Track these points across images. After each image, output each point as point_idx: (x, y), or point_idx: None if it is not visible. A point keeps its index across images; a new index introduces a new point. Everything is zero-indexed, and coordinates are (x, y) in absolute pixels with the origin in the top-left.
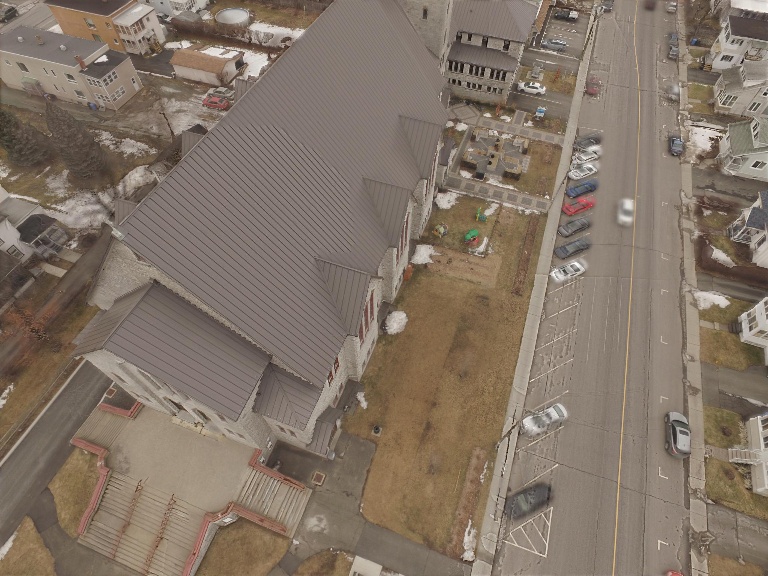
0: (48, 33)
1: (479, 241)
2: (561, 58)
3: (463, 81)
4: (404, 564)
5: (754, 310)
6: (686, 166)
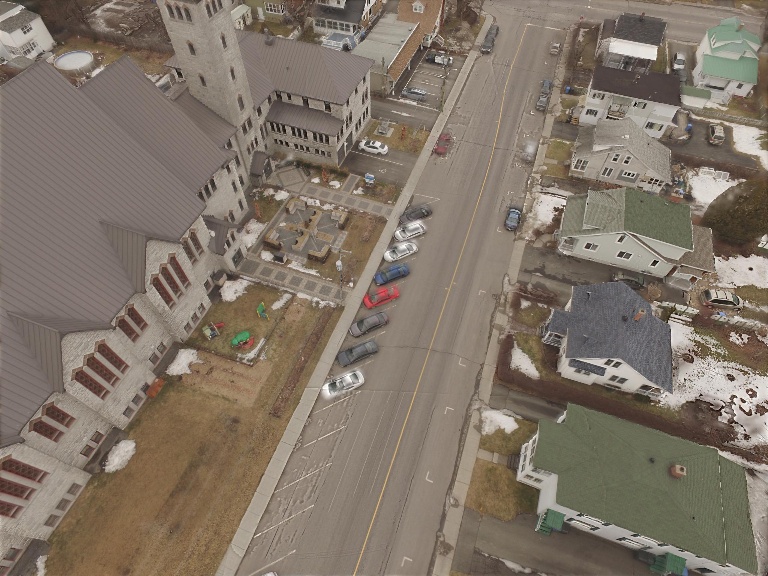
0: None
1: (253, 344)
2: (420, 109)
3: (290, 142)
4: None
5: (527, 446)
6: (520, 243)
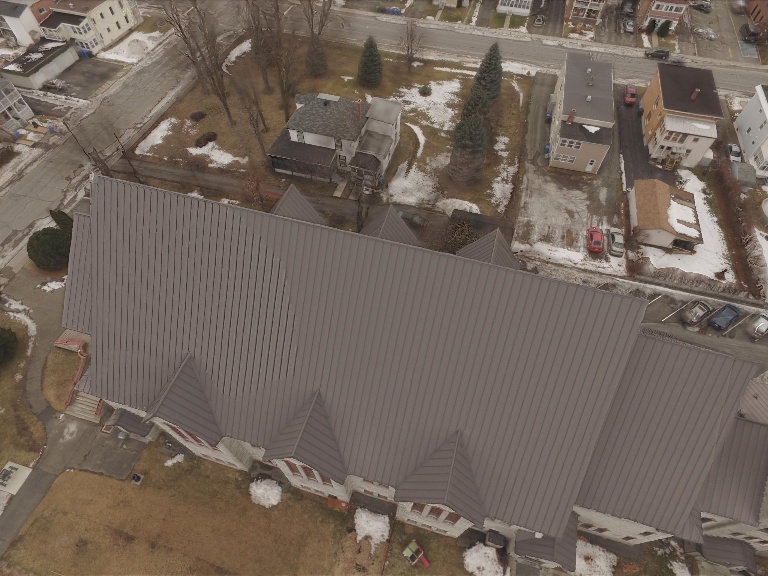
0: (609, 82)
1: None
2: None
3: None
4: (8, 516)
5: None
6: None
